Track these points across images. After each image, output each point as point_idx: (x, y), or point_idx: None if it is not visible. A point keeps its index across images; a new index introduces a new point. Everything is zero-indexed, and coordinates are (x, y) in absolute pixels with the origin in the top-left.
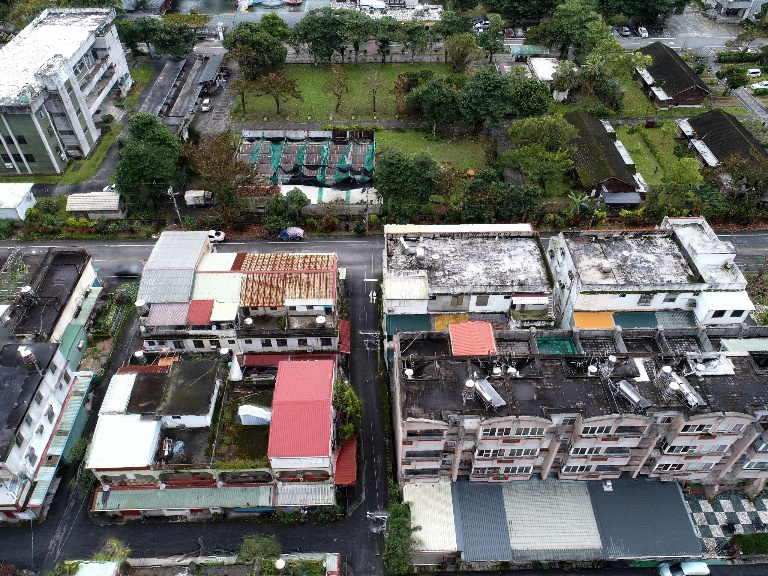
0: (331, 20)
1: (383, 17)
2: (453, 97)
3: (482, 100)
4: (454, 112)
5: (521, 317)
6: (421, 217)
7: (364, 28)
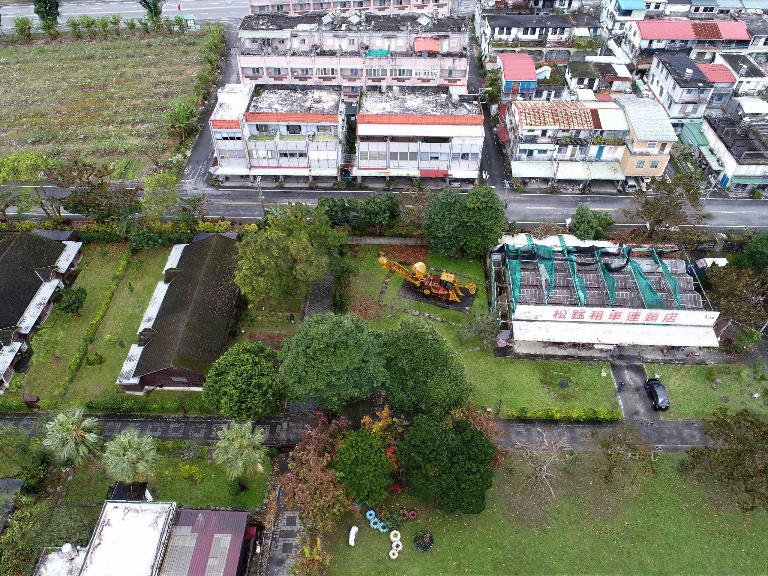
0: None
1: None
2: None
3: None
4: None
5: None
6: None
7: None
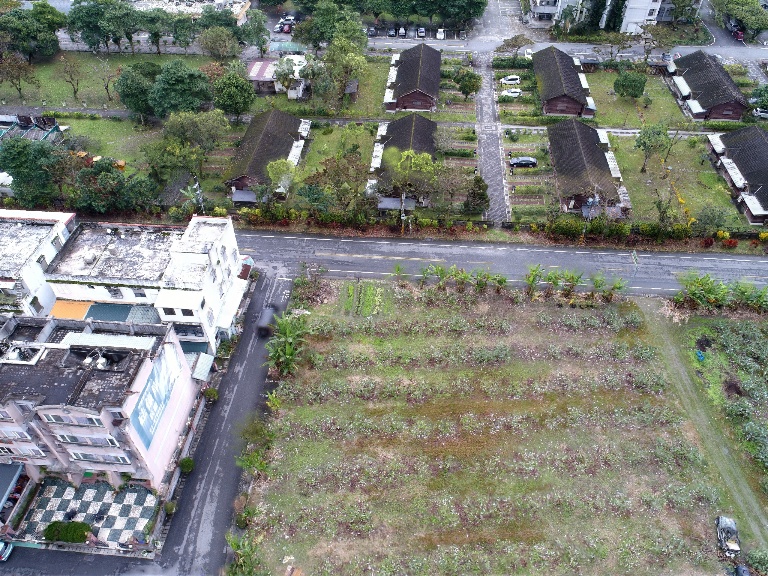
0: (96, 10)
1: (153, 9)
2: (141, 89)
3: (165, 93)
4: (143, 104)
5: (2, 300)
6: (57, 203)
7: (123, 19)
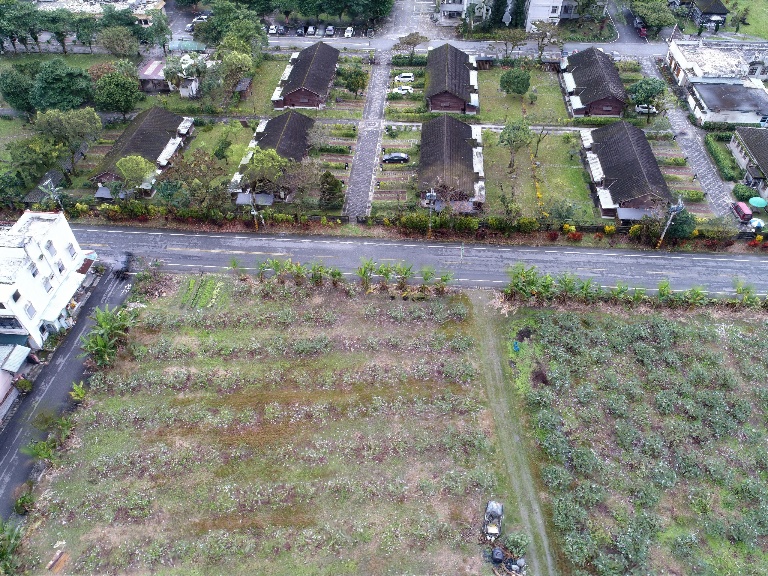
0: None
1: (56, 9)
2: (21, 88)
3: (44, 92)
4: (24, 102)
5: None
6: None
7: (24, 19)
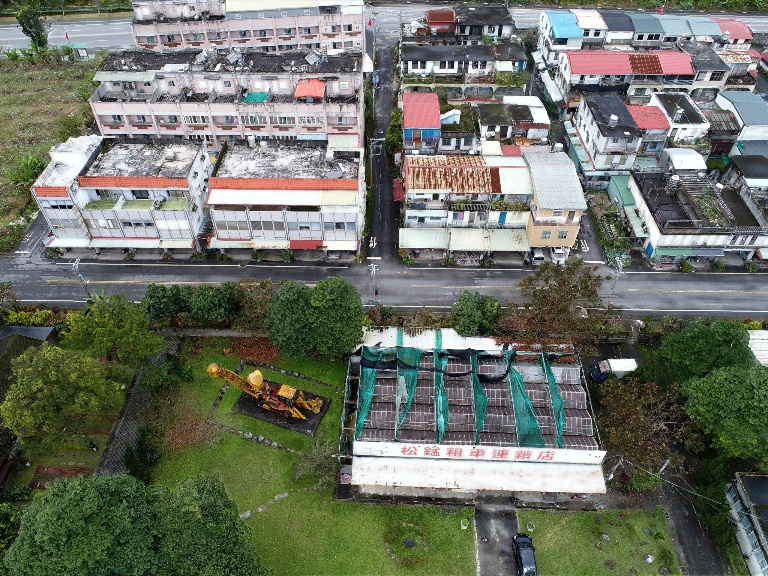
0: None
1: None
2: None
3: None
4: None
5: None
6: None
7: None
